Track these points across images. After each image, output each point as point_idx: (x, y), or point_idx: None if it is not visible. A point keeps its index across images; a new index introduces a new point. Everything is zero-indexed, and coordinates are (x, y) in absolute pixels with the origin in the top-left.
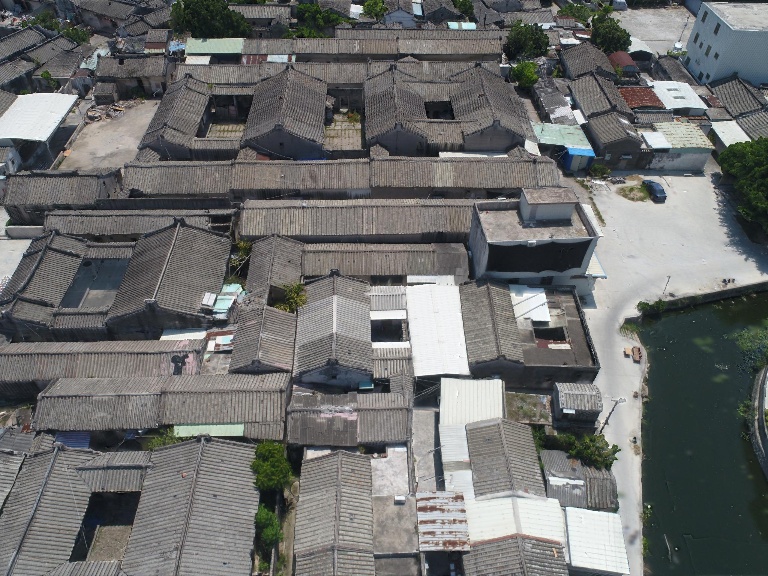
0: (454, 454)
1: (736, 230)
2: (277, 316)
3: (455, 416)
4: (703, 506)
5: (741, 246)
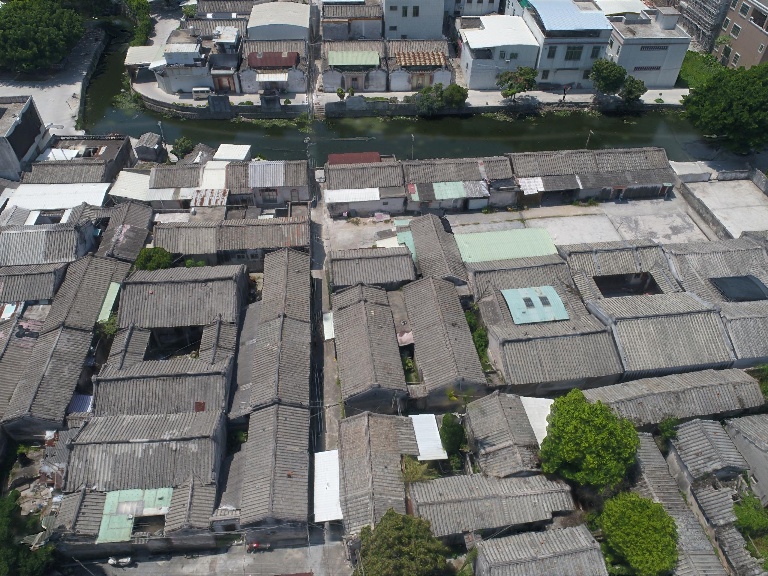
0: (168, 194)
1: (29, 84)
2: (2, 272)
3: (140, 193)
4: (217, 139)
5: (46, 85)
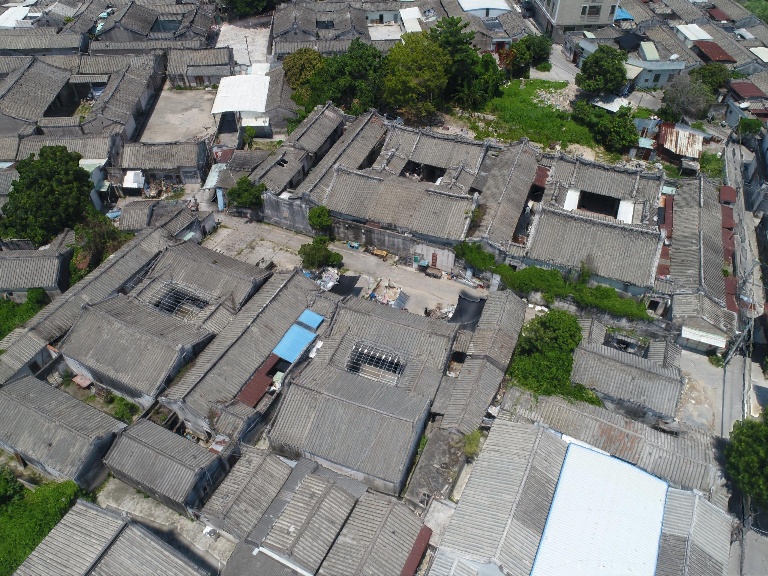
0: None
1: None
2: None
3: None
4: None
5: None
